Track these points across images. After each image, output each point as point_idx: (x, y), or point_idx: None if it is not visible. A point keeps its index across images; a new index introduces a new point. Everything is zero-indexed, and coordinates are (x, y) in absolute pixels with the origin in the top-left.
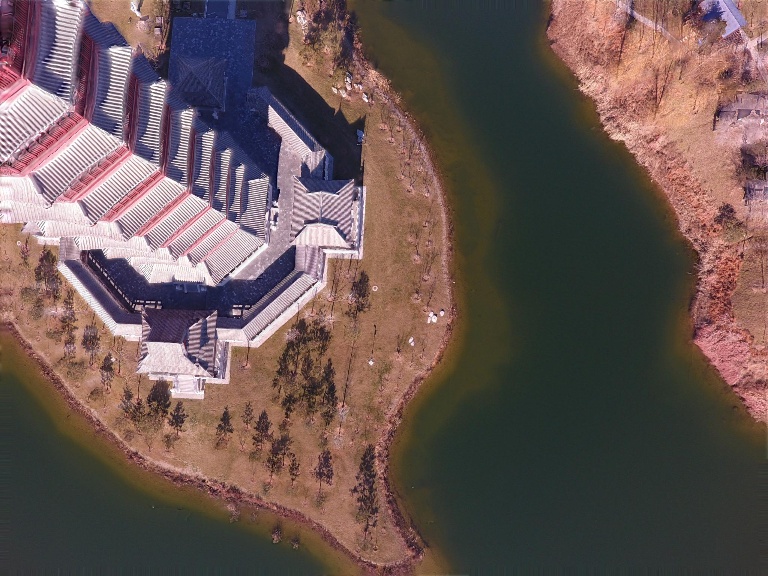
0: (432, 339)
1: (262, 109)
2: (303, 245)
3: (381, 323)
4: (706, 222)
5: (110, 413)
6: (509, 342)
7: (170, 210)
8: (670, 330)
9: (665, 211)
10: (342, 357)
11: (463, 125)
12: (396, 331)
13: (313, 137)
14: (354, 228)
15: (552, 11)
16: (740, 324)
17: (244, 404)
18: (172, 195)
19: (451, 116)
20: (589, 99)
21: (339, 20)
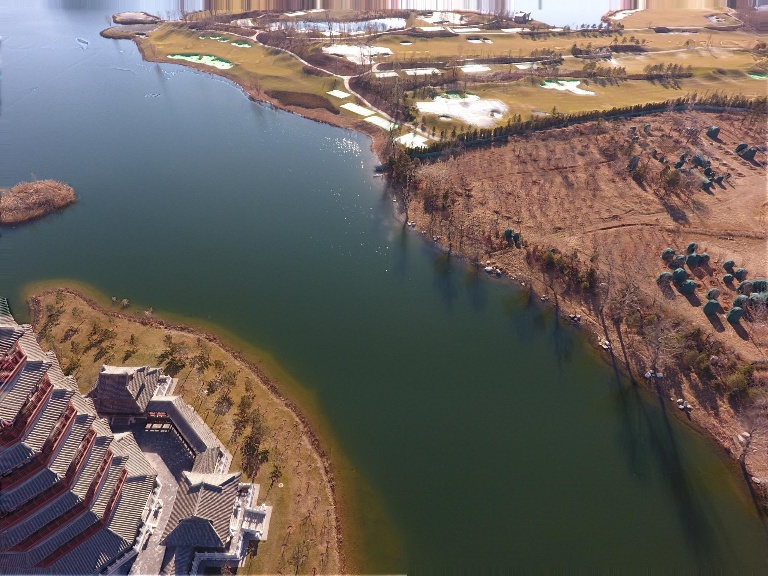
0: None
1: None
2: None
3: None
4: None
5: None
6: None
7: None
8: None
9: None
10: None
11: None
12: None
13: None
14: None
15: None
16: None
17: None
18: None
19: None
20: None
21: None
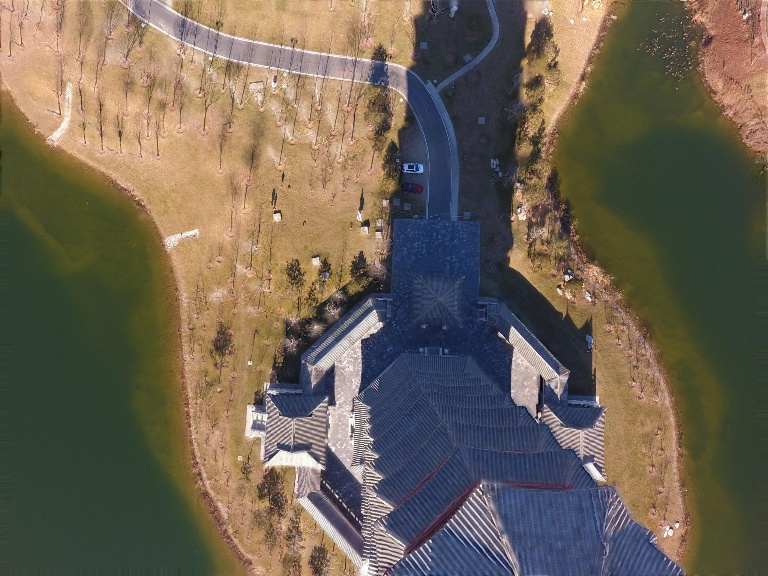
0: (668, 553)
1: (502, 328)
2: None
3: None
4: None
5: None
6: (744, 552)
7: None
8: None
9: None
10: None
11: (685, 320)
12: None
13: None
14: None
15: None
16: None
17: None
18: None
19: (672, 310)
20: None
21: (555, 211)
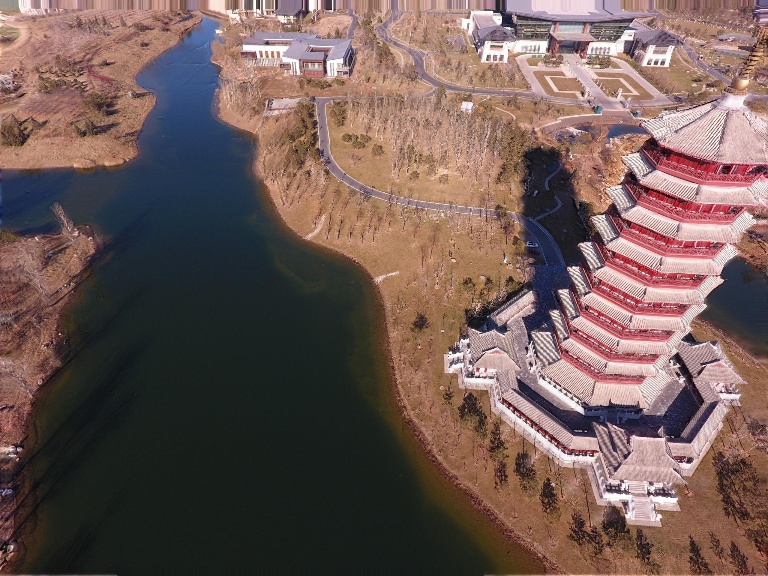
0: None
1: None
2: (704, 383)
3: None
4: None
5: (559, 546)
6: None
7: None
8: None
9: None
10: None
11: (748, 329)
12: None
13: None
14: None
15: (764, 273)
16: None
17: (707, 533)
18: (715, 284)
19: (735, 324)
20: None
21: None
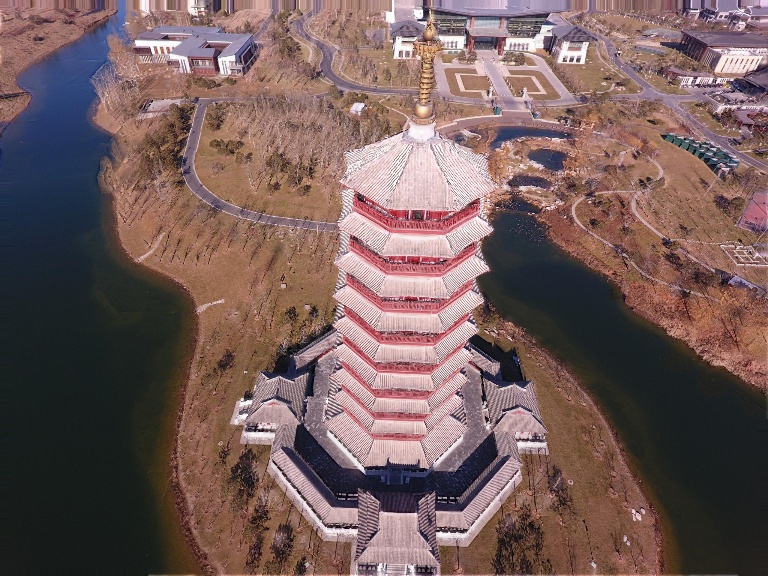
0: (645, 540)
1: None
2: (503, 432)
3: (589, 518)
4: None
5: None
6: (725, 545)
7: (452, 355)
8: None
9: None
10: (561, 557)
11: (589, 358)
12: (607, 527)
13: None
14: None
15: (623, 292)
16: None
17: None
18: (469, 335)
19: (577, 352)
20: (678, 341)
21: None
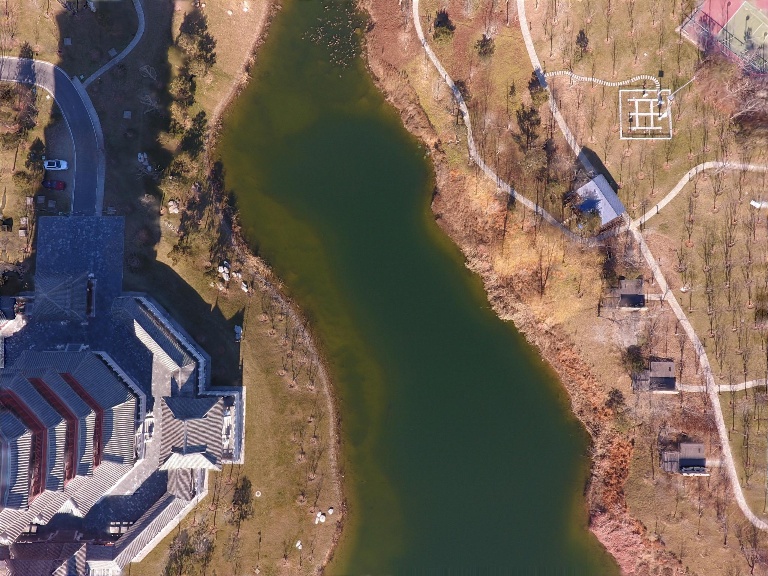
0: (321, 539)
1: (128, 322)
2: None
3: (266, 530)
4: (597, 405)
5: None
6: (402, 535)
7: None
8: (567, 513)
9: (558, 390)
10: (227, 567)
11: (349, 307)
12: (282, 536)
13: (189, 336)
14: (232, 436)
15: (436, 184)
16: (633, 514)
17: None
18: None
19: (336, 297)
20: (477, 275)
21: (216, 203)
